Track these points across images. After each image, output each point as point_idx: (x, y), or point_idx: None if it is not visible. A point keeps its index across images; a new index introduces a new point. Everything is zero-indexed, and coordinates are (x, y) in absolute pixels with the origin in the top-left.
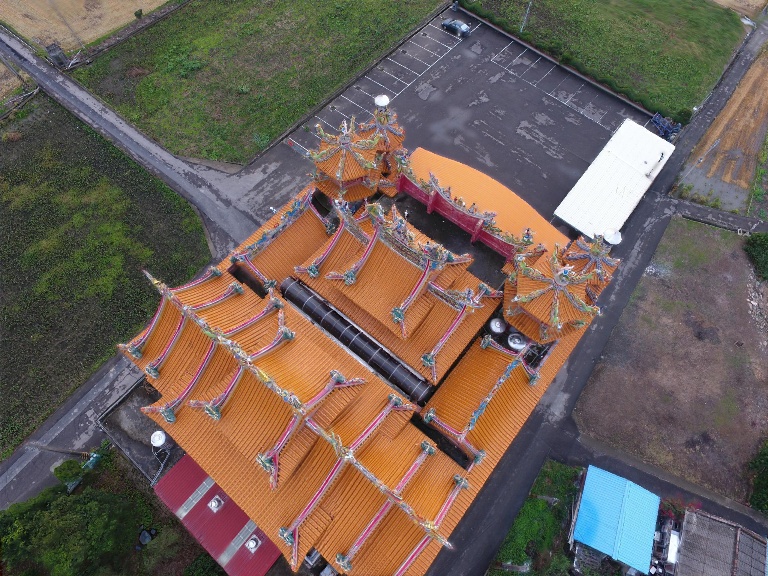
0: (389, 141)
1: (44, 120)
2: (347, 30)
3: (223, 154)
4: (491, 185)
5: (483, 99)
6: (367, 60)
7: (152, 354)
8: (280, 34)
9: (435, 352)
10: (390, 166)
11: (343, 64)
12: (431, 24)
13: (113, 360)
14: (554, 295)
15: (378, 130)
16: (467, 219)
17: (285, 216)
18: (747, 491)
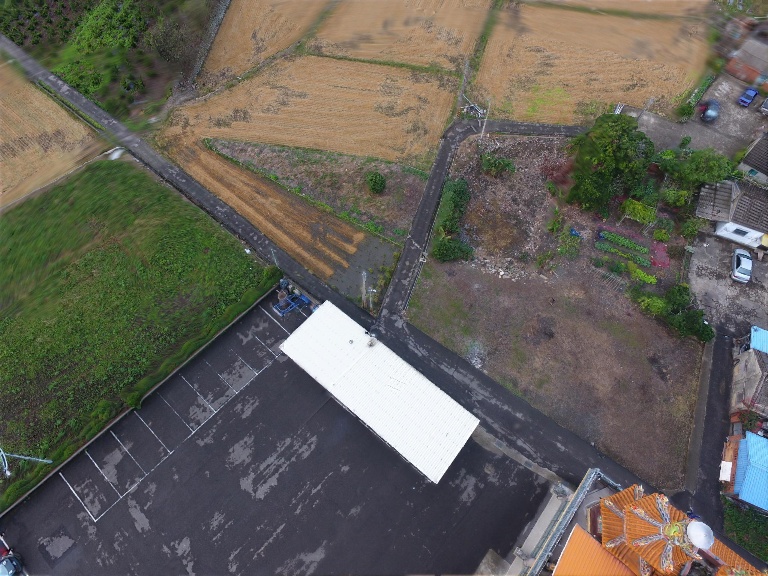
0: None
1: None
2: None
3: None
4: None
5: (183, 549)
6: None
7: None
8: None
9: None
10: None
11: None
12: None
13: None
14: None
15: None
16: None
17: None
18: (691, 339)
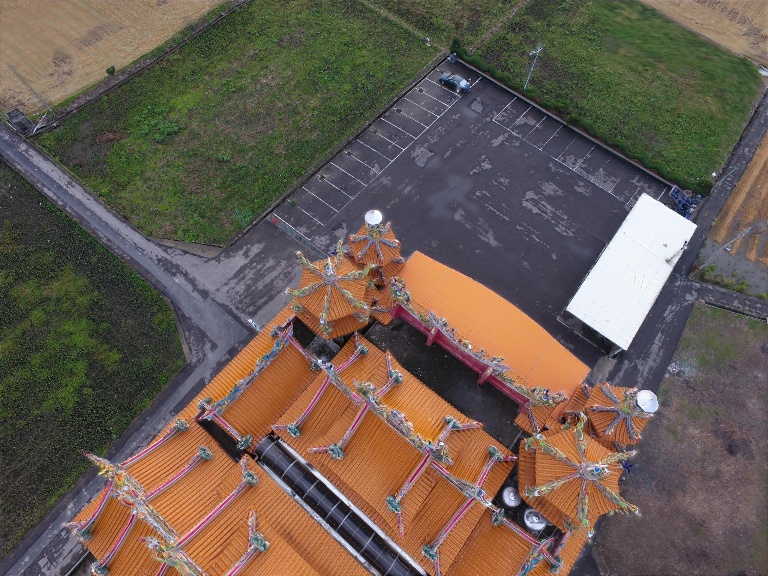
0: (382, 257)
1: (4, 196)
2: (337, 86)
3: (201, 234)
4: (499, 305)
5: (485, 166)
6: (359, 121)
7: (104, 533)
8: (265, 91)
9: (439, 545)
10: (384, 279)
11: (333, 126)
12: (428, 78)
13: (72, 493)
14: (581, 485)
15: (370, 243)
16: (473, 360)
17: (261, 361)
18: None
